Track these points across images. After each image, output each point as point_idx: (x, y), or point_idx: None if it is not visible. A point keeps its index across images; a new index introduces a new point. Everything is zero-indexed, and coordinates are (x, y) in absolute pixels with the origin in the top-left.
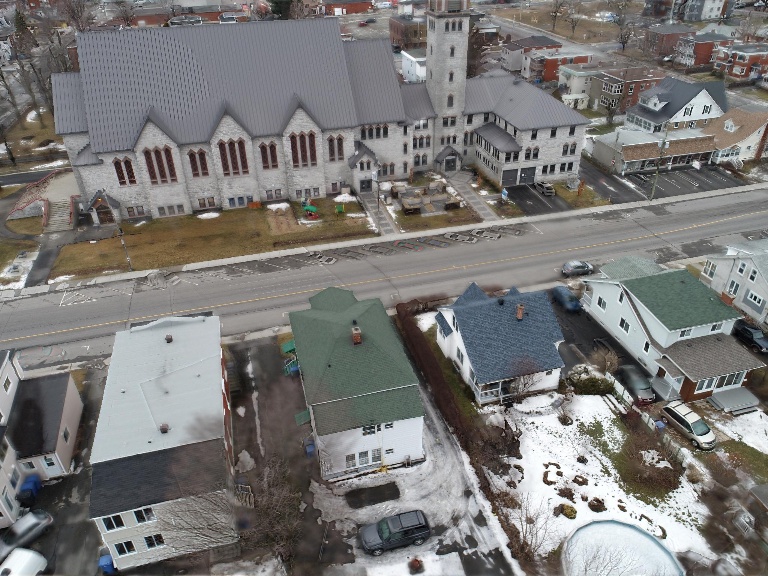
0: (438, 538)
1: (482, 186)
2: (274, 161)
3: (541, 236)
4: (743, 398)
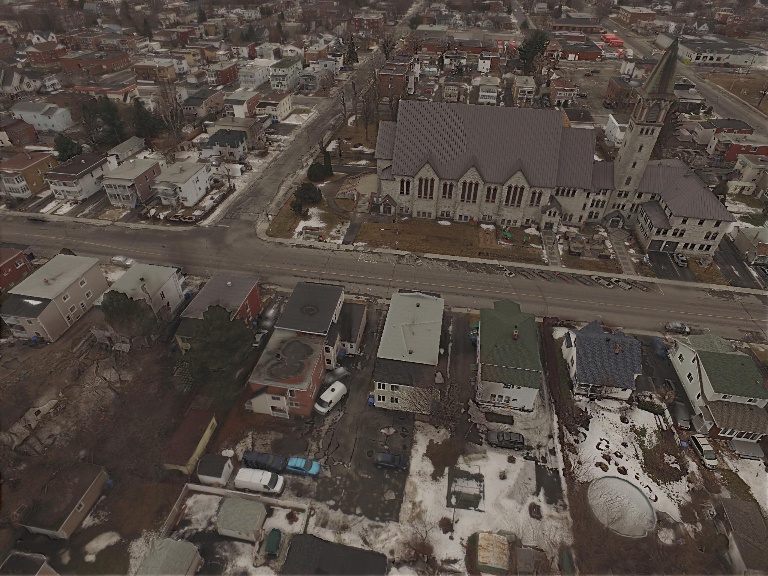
0: (527, 451)
1: (633, 245)
2: (493, 198)
3: (661, 296)
4: (753, 450)
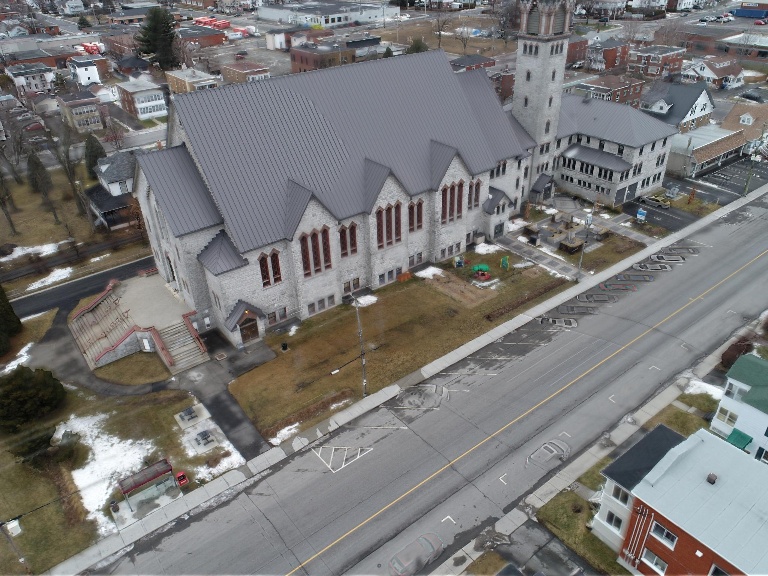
0: None
1: None
2: (418, 221)
3: (715, 250)
4: None
